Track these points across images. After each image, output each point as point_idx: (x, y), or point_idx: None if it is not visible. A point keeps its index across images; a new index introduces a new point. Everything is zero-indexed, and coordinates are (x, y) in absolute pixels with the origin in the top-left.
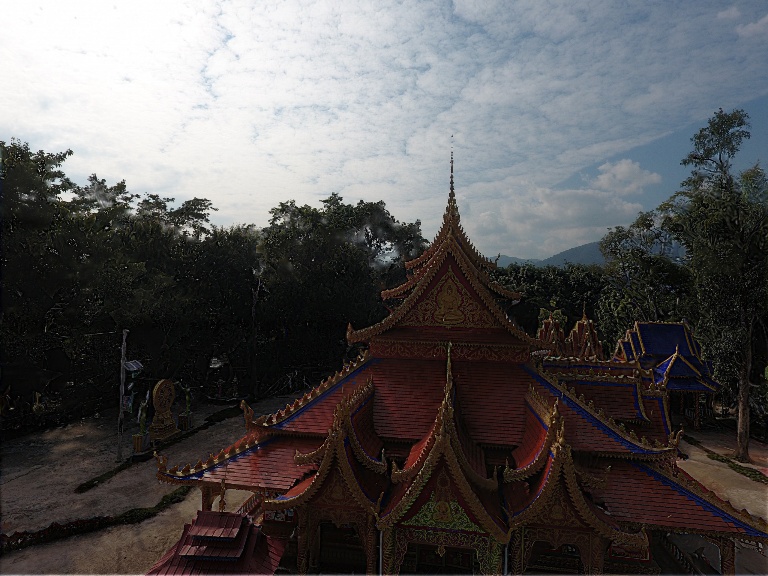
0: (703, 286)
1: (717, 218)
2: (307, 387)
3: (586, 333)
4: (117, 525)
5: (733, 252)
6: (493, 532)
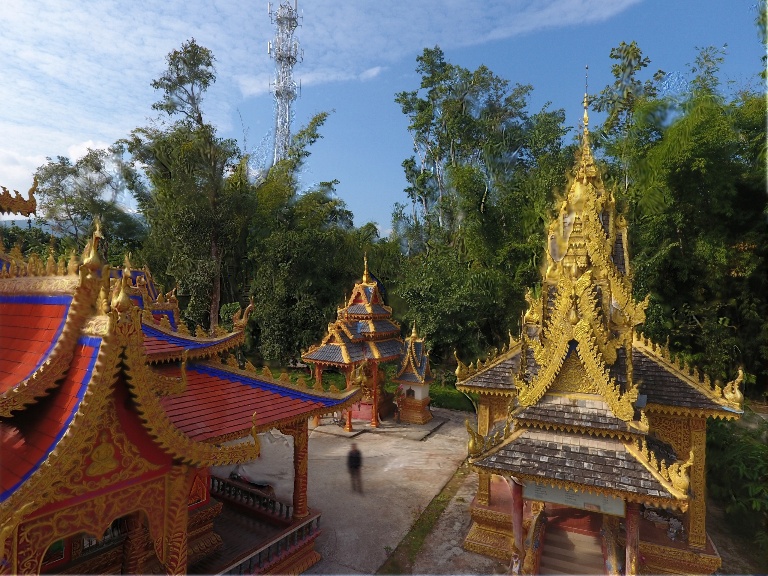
0: (179, 216)
1: (193, 146)
2: None
3: None
4: None
5: (209, 182)
6: None
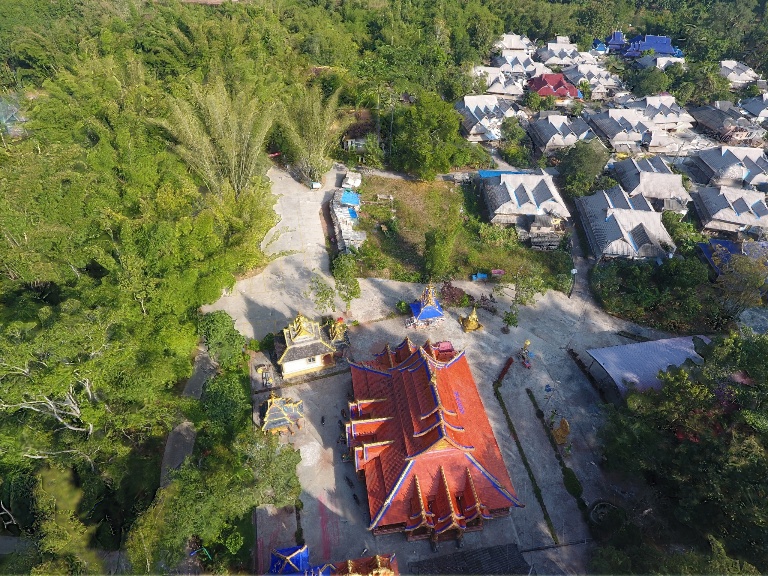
0: None
1: (284, 448)
2: None
3: None
4: None
5: None
6: None
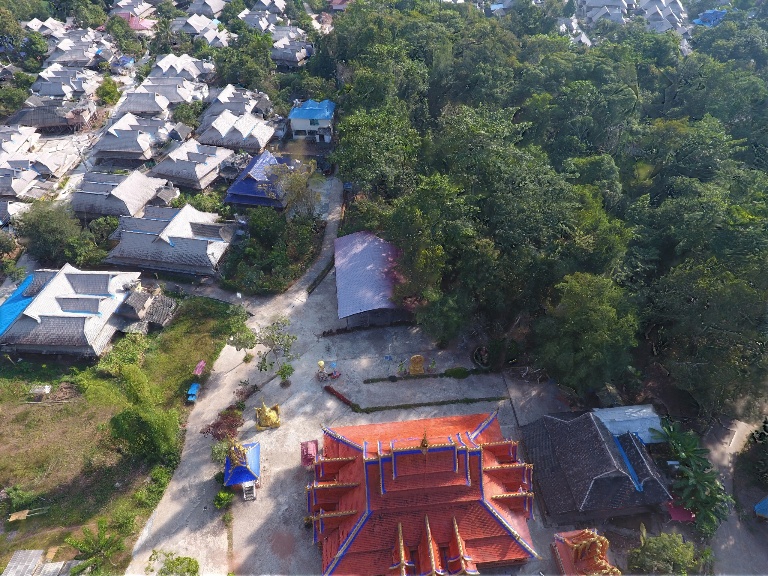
0: None
1: None
2: (537, 382)
3: (594, 573)
4: (350, 407)
5: None
6: None
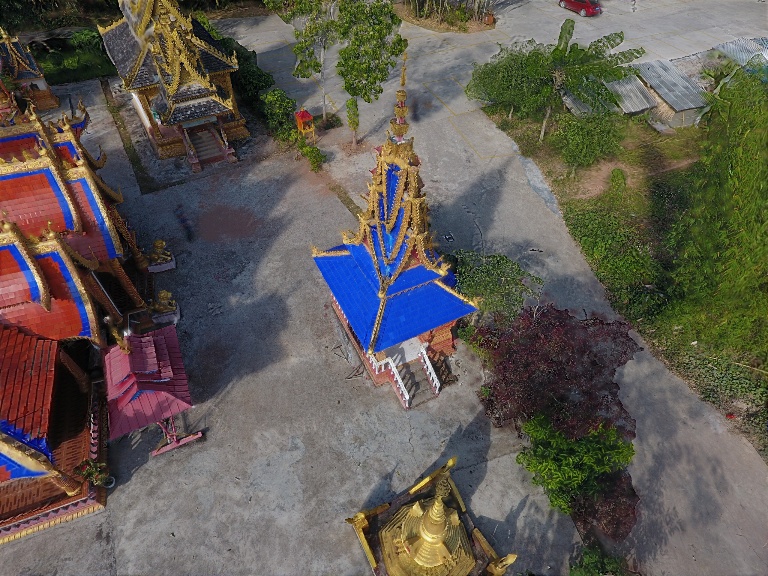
0: None
1: None
2: None
3: None
4: None
5: None
6: (120, 199)
